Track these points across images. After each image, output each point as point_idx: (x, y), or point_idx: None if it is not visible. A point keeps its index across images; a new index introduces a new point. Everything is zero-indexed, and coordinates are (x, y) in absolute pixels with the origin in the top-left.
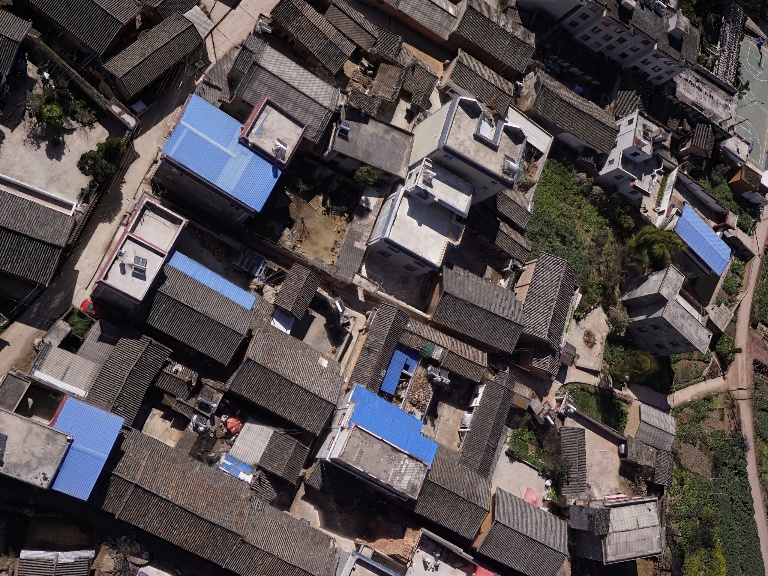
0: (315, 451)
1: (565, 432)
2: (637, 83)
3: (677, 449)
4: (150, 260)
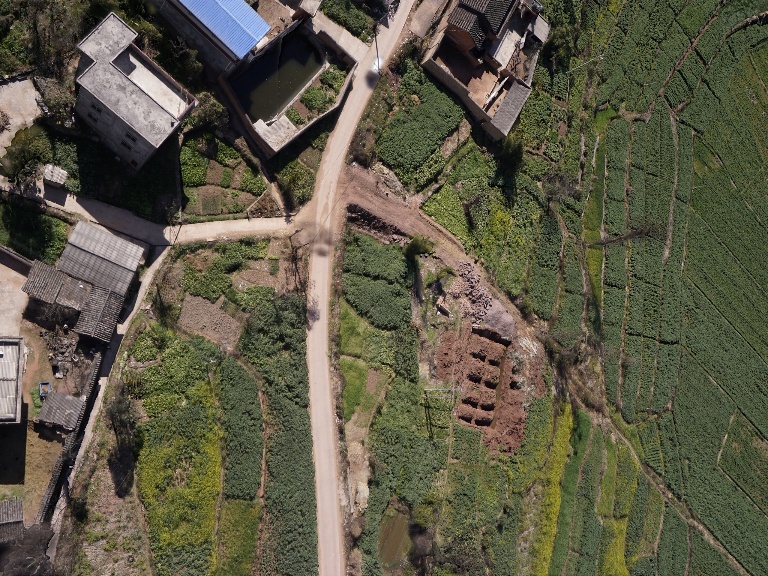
0: None
1: None
2: None
3: (172, 301)
4: None
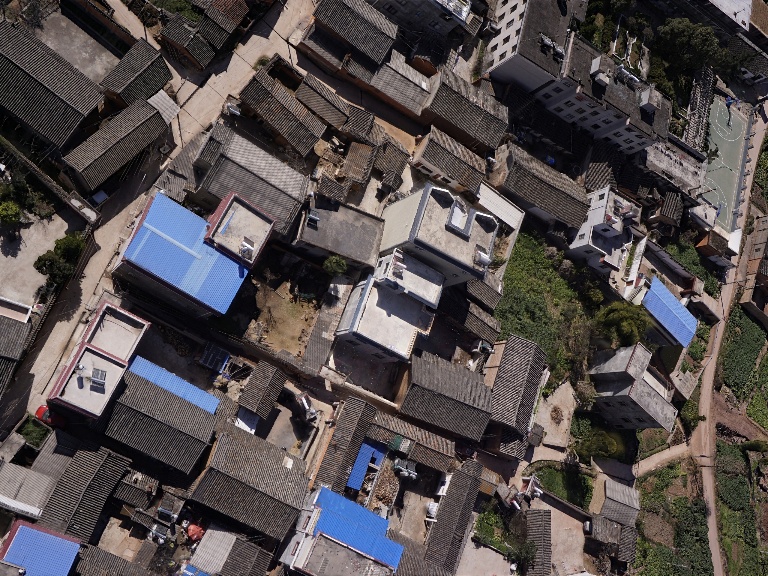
0: (279, 553)
1: (531, 515)
2: (609, 155)
3: (641, 519)
4: (109, 372)
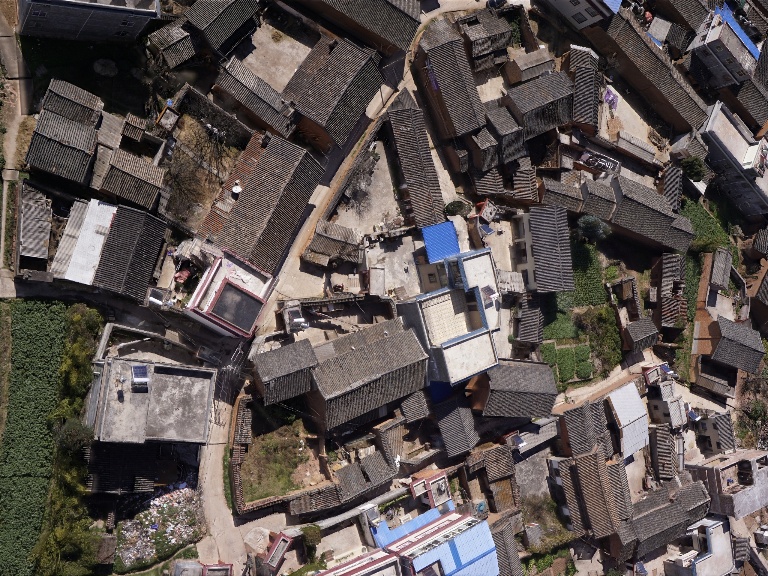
0: None
1: None
2: None
3: None
4: None
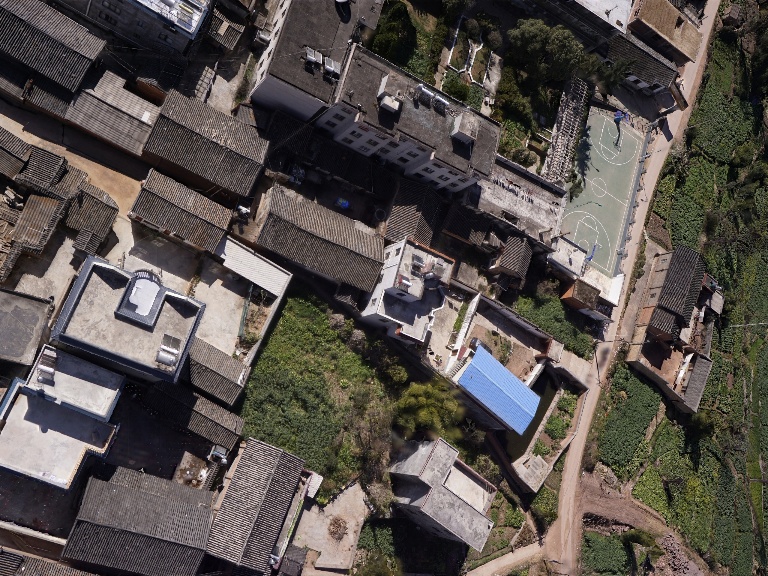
0: None
1: None
2: (419, 195)
3: None
4: None
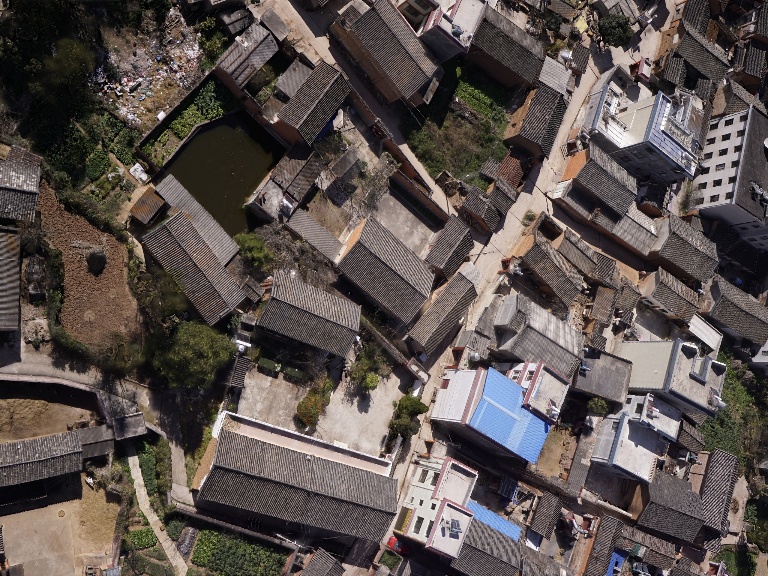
0: None
1: None
2: None
3: None
4: (461, 520)
